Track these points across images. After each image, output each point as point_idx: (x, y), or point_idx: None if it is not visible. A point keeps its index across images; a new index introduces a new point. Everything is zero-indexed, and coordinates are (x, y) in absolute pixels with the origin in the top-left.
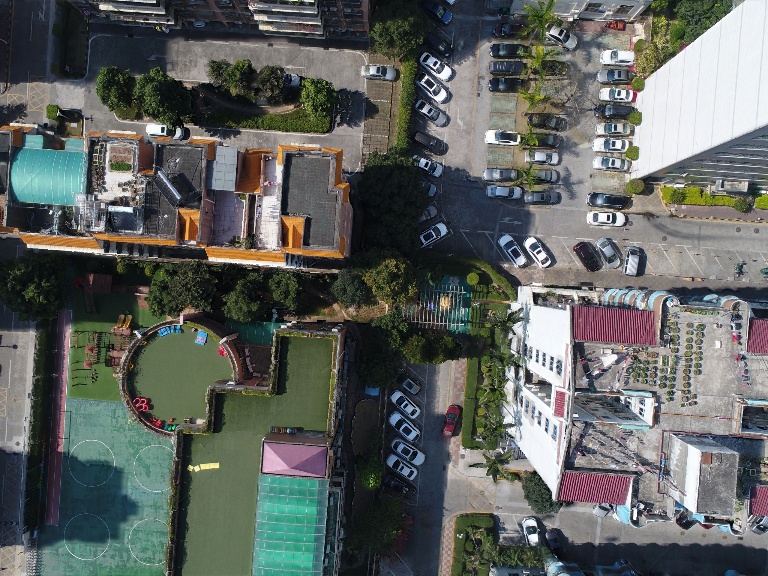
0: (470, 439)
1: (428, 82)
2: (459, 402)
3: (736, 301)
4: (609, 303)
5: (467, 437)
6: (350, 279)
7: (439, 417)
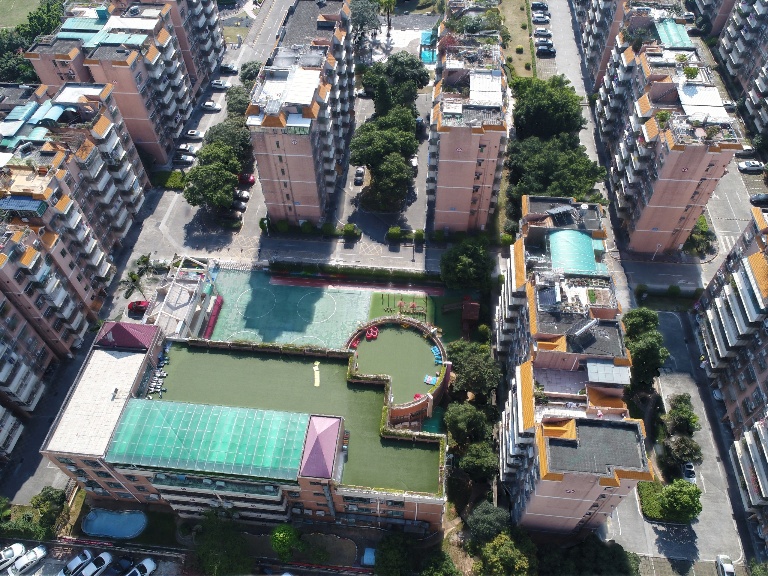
0: None
1: None
2: None
3: None
4: None
5: None
6: (501, 517)
7: None
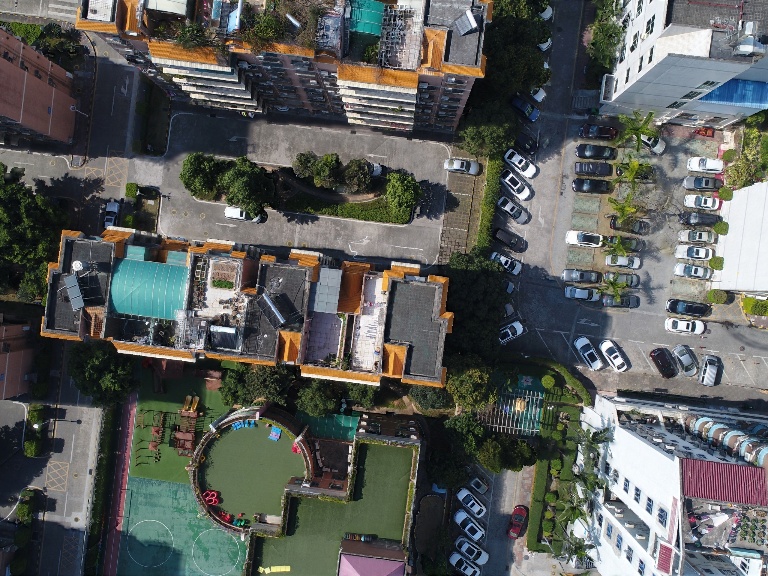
0: (536, 542)
1: (512, 180)
2: (525, 503)
3: None
4: (700, 433)
5: (533, 540)
6: None
7: (504, 516)
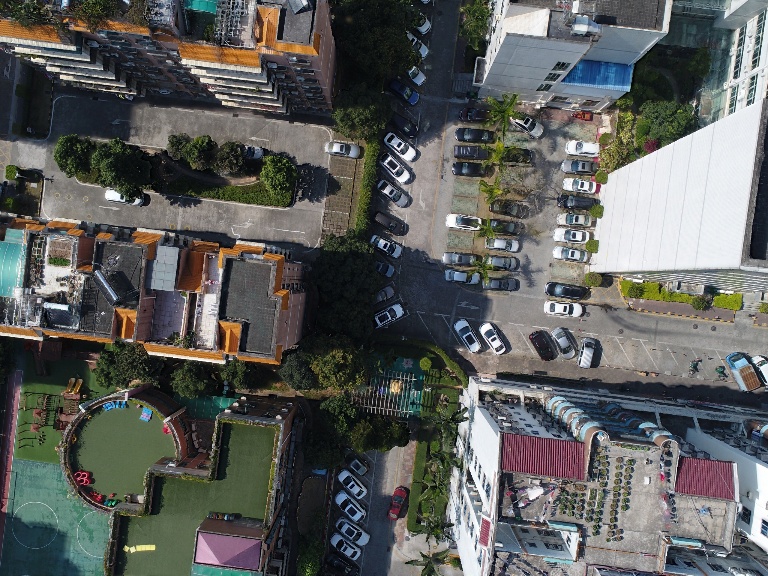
0: (415, 523)
1: (391, 163)
2: (407, 484)
3: (666, 440)
4: (552, 412)
5: (412, 521)
6: (297, 366)
7: (386, 498)
